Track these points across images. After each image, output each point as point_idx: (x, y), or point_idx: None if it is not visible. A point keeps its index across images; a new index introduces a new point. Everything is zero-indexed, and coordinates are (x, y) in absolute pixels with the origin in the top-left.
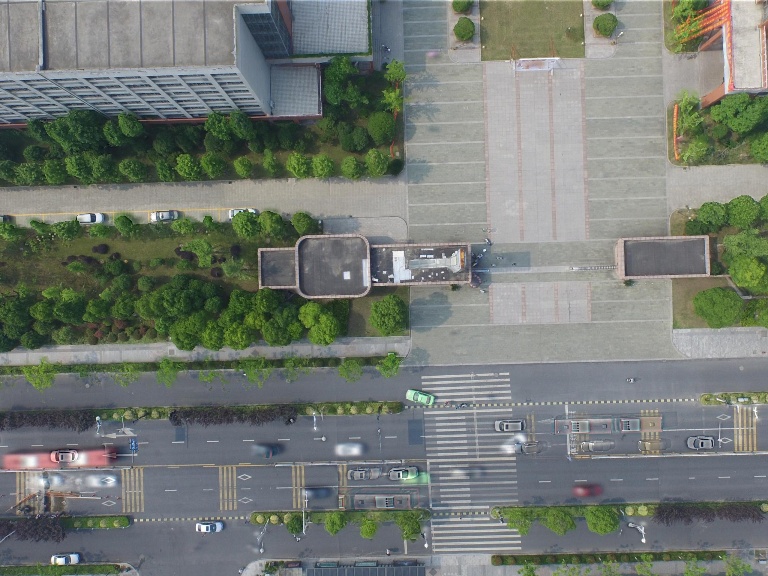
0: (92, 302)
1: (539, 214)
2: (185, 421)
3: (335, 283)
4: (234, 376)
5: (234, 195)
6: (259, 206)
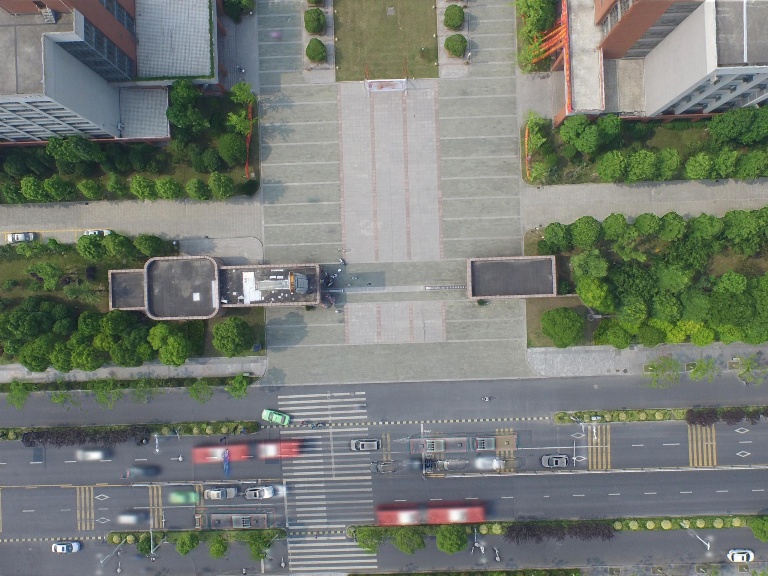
0: None
1: (394, 234)
2: (39, 442)
3: (185, 304)
4: (91, 397)
5: (91, 216)
6: (115, 227)
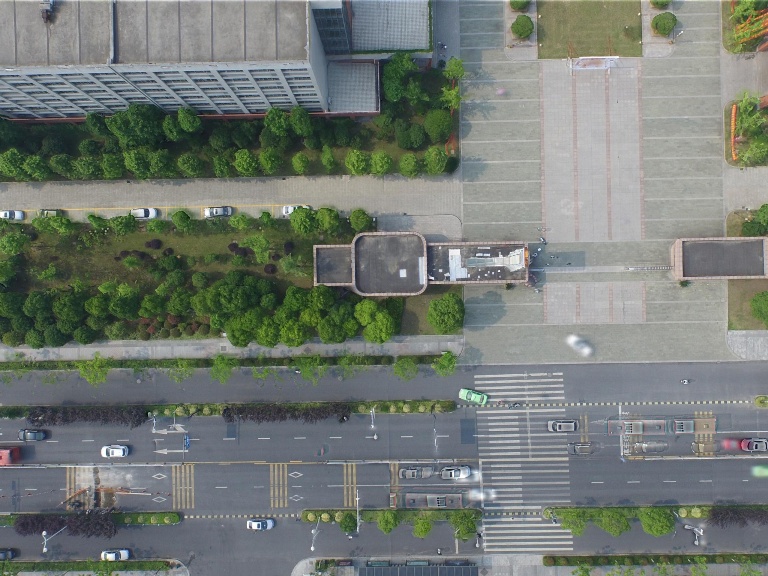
0: (148, 297)
1: (594, 214)
2: (238, 418)
3: (391, 281)
4: (286, 373)
5: (288, 191)
6: (313, 203)
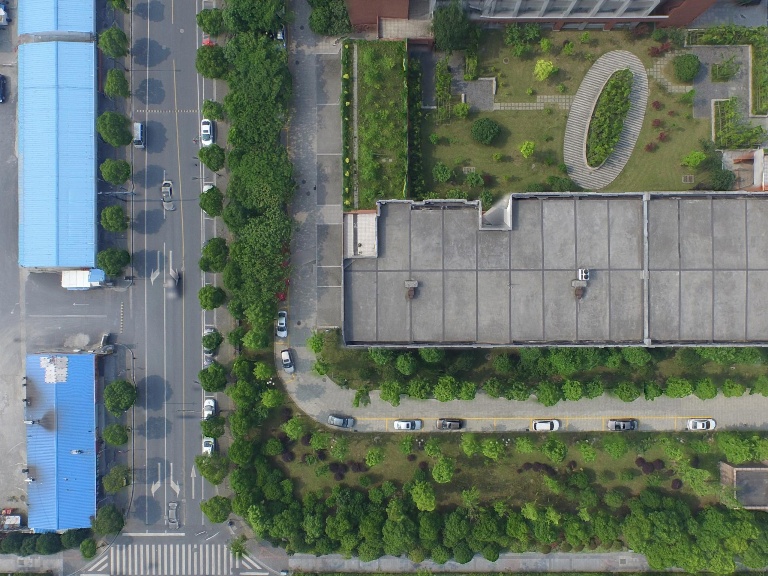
0: (578, 525)
1: None
2: None
3: None
4: None
5: (691, 404)
6: (716, 416)
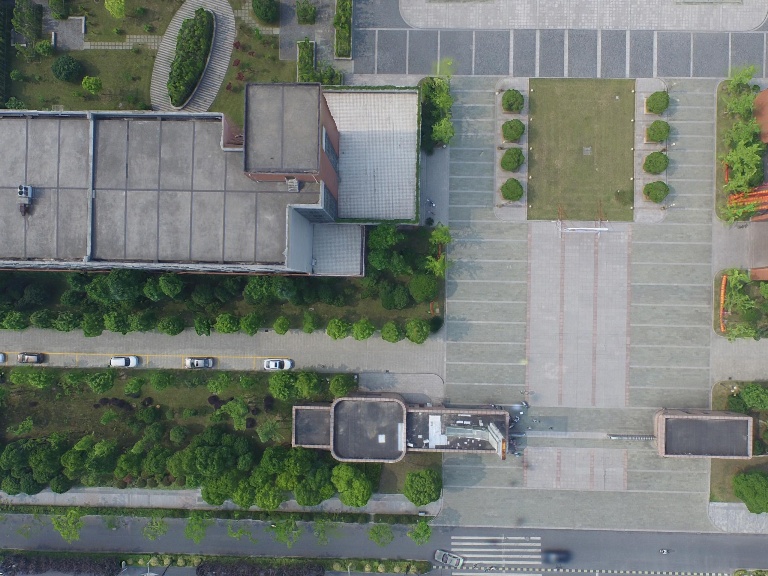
0: (124, 457)
1: (579, 379)
2: (211, 574)
3: (369, 446)
4: (262, 526)
5: (270, 344)
6: (295, 356)
